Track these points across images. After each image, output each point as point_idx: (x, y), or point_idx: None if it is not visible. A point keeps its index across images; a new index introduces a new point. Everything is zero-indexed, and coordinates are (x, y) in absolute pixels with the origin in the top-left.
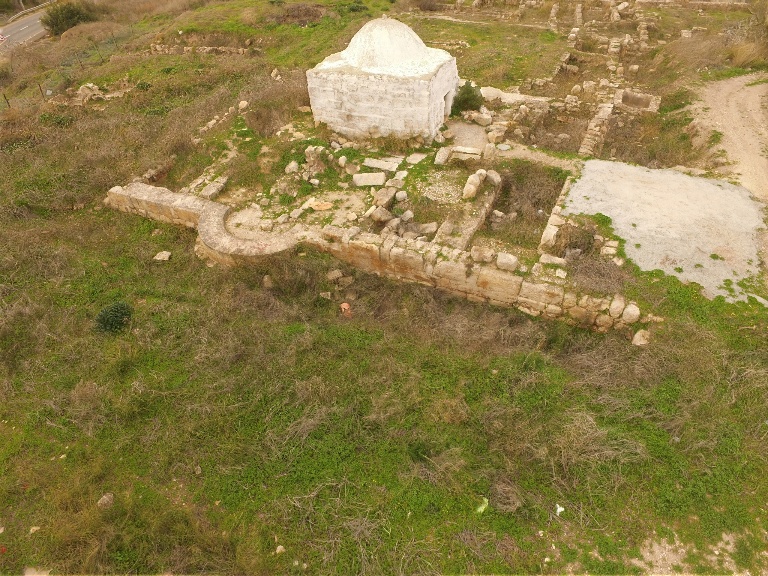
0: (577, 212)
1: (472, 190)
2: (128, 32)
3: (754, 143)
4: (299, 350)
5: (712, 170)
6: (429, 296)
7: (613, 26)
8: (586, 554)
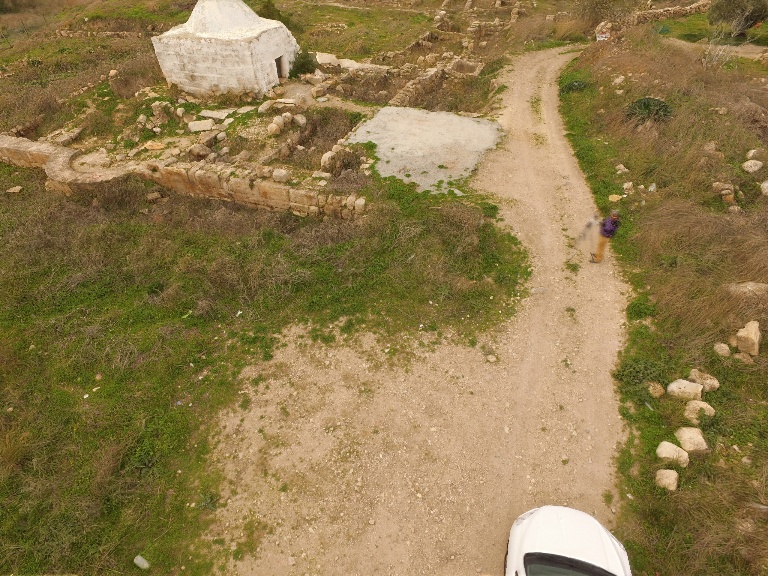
0: (355, 142)
1: (274, 128)
2: (43, 22)
3: (529, 93)
4: (91, 236)
5: (488, 114)
6: (221, 205)
7: (491, 12)
8: (243, 333)
